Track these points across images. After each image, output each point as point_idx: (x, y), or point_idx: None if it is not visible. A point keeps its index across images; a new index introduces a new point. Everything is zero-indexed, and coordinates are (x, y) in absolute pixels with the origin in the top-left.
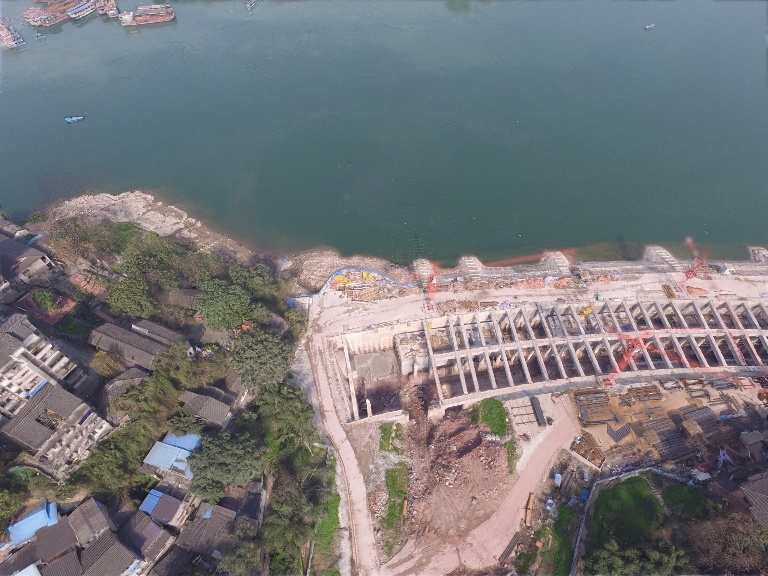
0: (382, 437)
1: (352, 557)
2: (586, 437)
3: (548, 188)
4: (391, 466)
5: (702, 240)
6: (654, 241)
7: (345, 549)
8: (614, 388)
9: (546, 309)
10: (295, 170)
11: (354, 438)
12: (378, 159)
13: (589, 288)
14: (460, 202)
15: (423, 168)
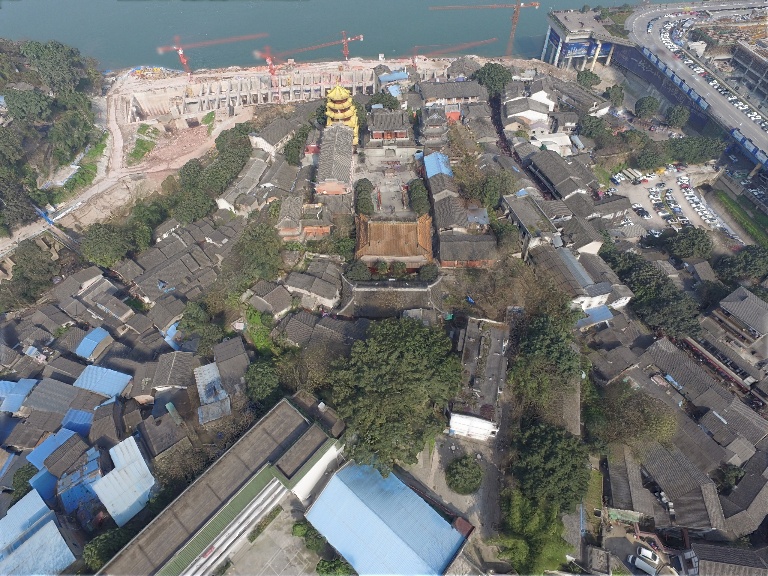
0: (140, 128)
1: (108, 166)
2: (253, 119)
3: (304, 33)
4: (143, 139)
5: (389, 54)
6: (359, 56)
7: (104, 162)
8: (281, 103)
9: (265, 81)
10: (131, 30)
11: (123, 129)
12: (193, 23)
13: (294, 69)
14: (241, 42)
15: (223, 26)
